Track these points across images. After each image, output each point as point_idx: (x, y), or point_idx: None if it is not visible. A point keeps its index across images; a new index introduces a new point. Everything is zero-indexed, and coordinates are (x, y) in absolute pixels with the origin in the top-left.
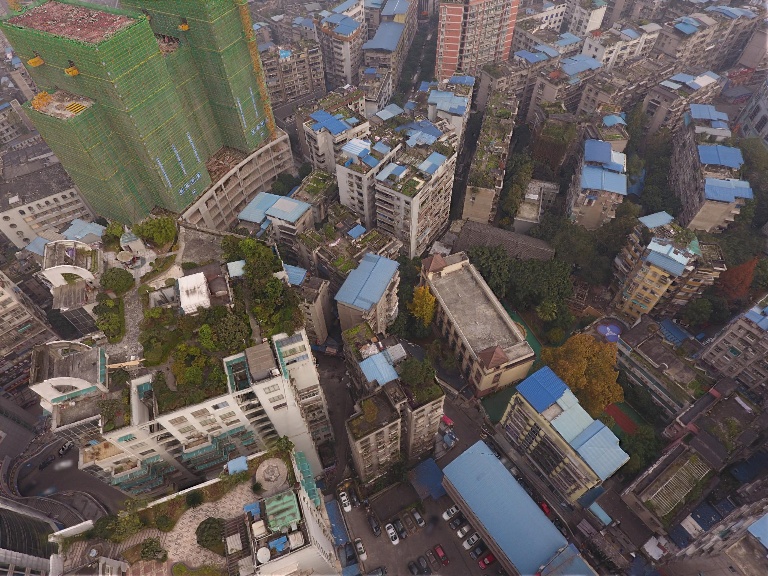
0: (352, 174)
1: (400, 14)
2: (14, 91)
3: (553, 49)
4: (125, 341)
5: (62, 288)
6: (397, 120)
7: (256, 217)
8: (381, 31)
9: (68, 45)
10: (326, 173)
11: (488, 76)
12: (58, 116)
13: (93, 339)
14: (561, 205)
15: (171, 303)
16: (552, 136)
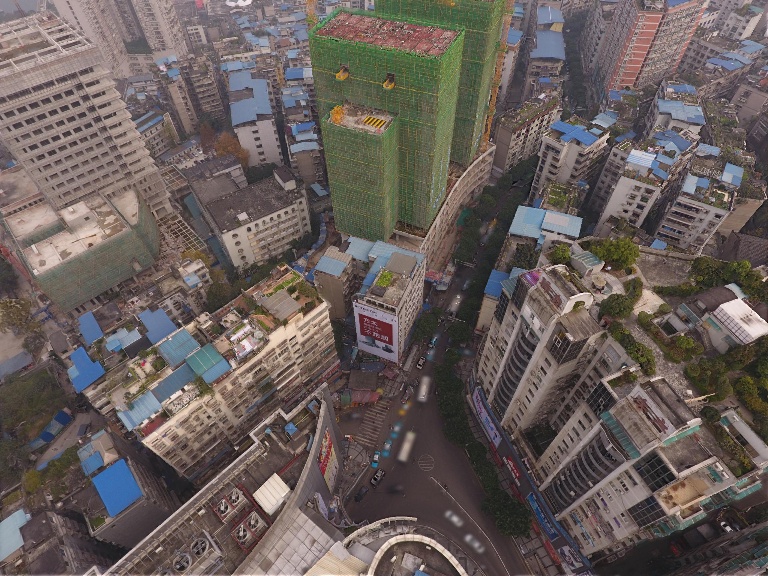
0: (641, 187)
1: (559, 23)
2: (150, 104)
3: (742, 56)
4: (660, 373)
5: (567, 317)
6: (617, 130)
7: (532, 232)
8: (541, 40)
9: (401, 58)
10: (563, 185)
11: None
12: (363, 131)
13: (631, 372)
14: None
15: (685, 331)
16: None
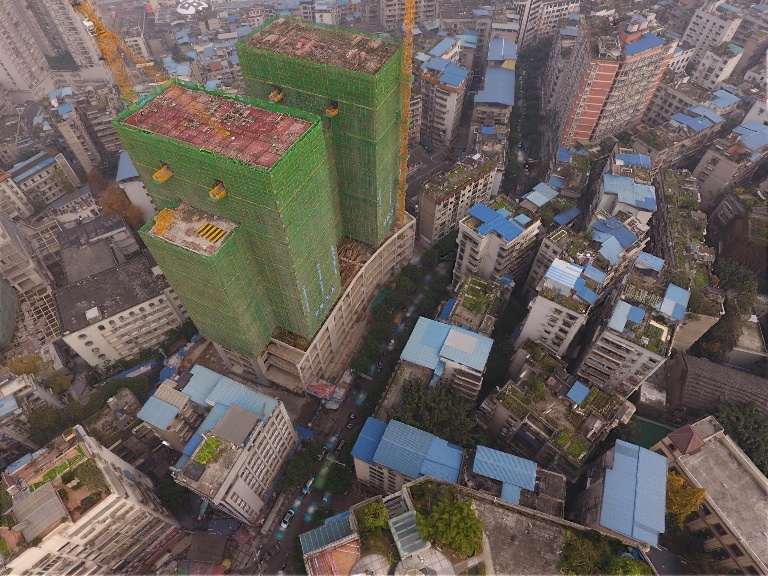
0: (562, 311)
1: (511, 59)
2: (53, 137)
3: (712, 112)
4: None
5: None
6: (556, 207)
7: (428, 359)
8: (490, 79)
9: (224, 164)
10: (484, 281)
11: (644, 146)
12: (191, 247)
13: None
14: (765, 318)
15: None
16: (764, 238)
